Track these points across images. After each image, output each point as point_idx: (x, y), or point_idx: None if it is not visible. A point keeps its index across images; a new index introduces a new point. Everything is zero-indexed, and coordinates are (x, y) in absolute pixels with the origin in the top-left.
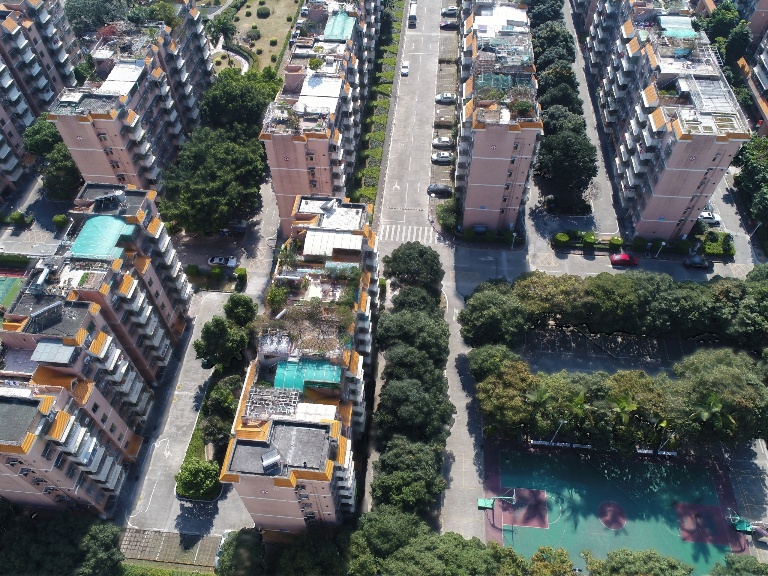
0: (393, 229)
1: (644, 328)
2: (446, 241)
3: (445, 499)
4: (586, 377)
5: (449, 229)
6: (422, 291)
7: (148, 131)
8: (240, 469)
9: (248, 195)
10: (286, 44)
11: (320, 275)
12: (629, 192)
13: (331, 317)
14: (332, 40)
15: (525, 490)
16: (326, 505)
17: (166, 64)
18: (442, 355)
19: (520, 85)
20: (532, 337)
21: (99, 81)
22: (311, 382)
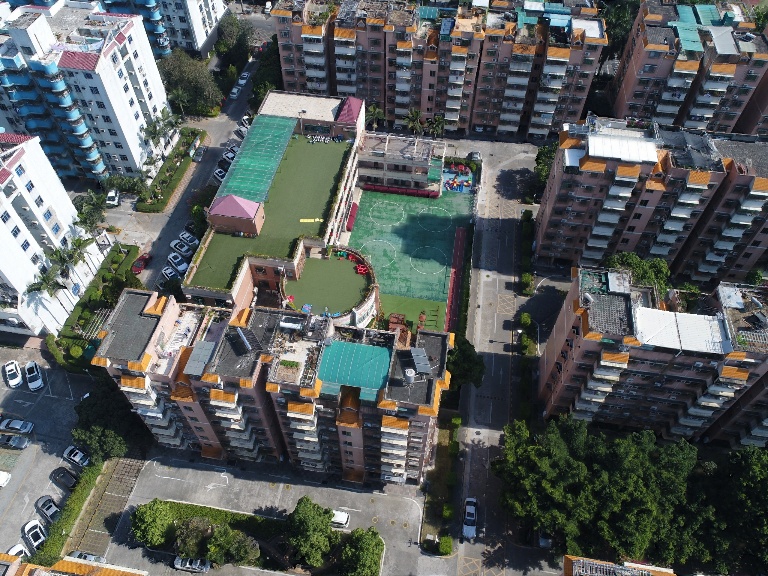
0: None
1: None
2: None
3: None
4: None
5: None
6: None
7: (638, 384)
8: None
9: None
10: None
11: None
12: None
13: None
14: None
15: None
16: None
17: None
18: None
19: None
20: None
21: (680, 305)
22: None
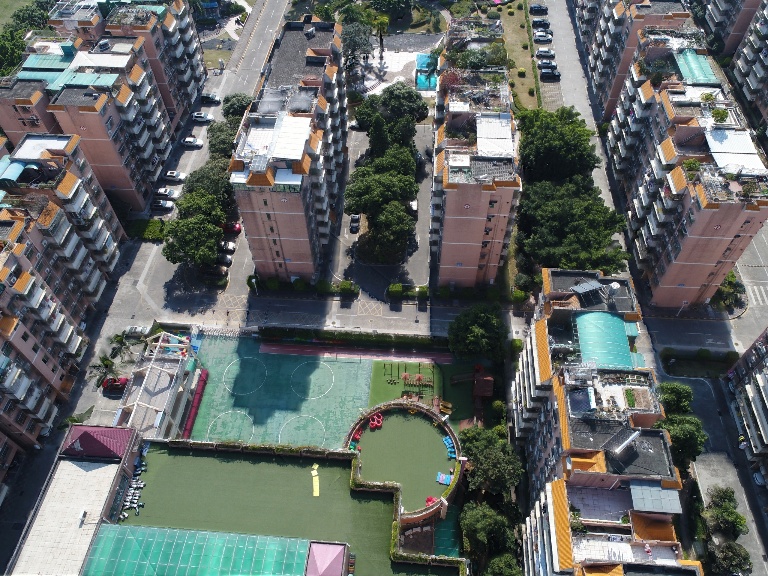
0: (763, 291)
1: None
2: None
3: None
4: None
5: None
6: None
7: None
8: None
9: None
10: (536, 75)
11: None
12: None
13: None
14: (702, 84)
15: None
16: None
17: None
18: None
19: None
20: None
21: (461, 138)
22: None
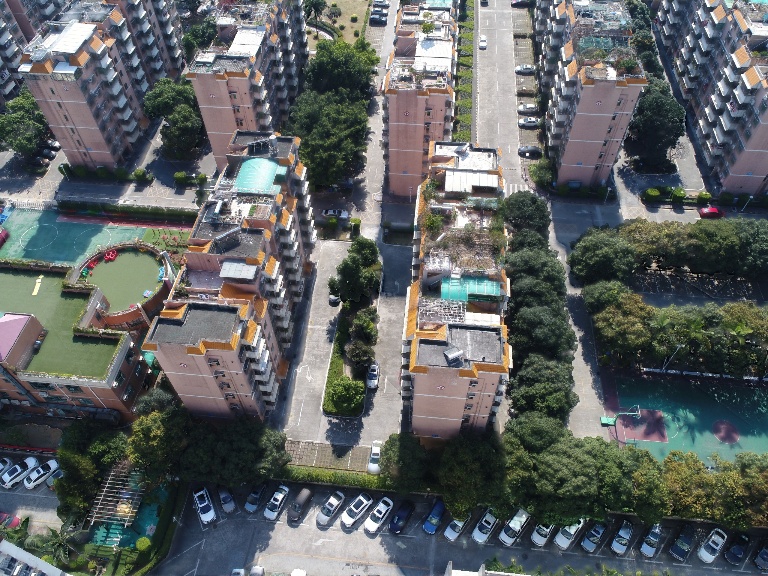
0: None
1: (745, 267)
2: (541, 197)
3: (570, 417)
4: (697, 309)
5: (543, 186)
6: (537, 234)
7: None
8: (427, 363)
9: (358, 152)
10: (366, 21)
11: (466, 207)
12: (717, 150)
13: (484, 241)
14: (436, 8)
15: (643, 410)
16: (485, 406)
17: (277, 32)
18: (562, 289)
19: (620, 47)
20: (633, 280)
21: (224, 45)
22: (473, 295)
